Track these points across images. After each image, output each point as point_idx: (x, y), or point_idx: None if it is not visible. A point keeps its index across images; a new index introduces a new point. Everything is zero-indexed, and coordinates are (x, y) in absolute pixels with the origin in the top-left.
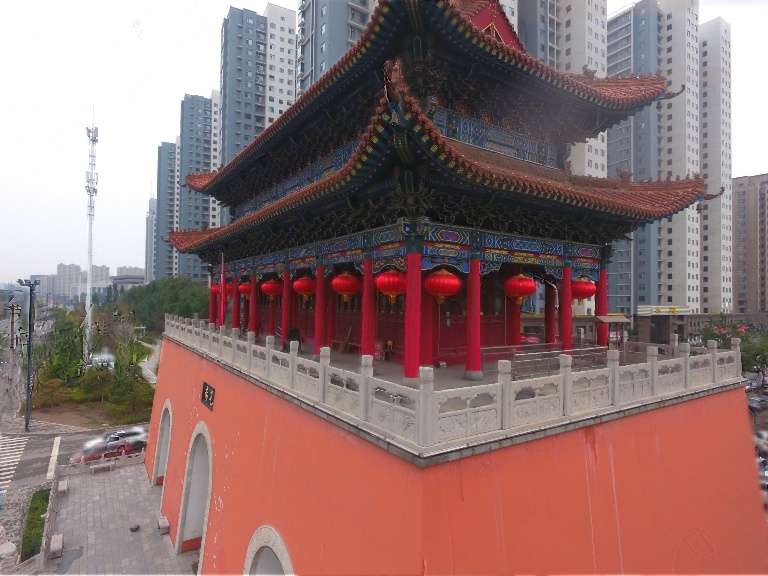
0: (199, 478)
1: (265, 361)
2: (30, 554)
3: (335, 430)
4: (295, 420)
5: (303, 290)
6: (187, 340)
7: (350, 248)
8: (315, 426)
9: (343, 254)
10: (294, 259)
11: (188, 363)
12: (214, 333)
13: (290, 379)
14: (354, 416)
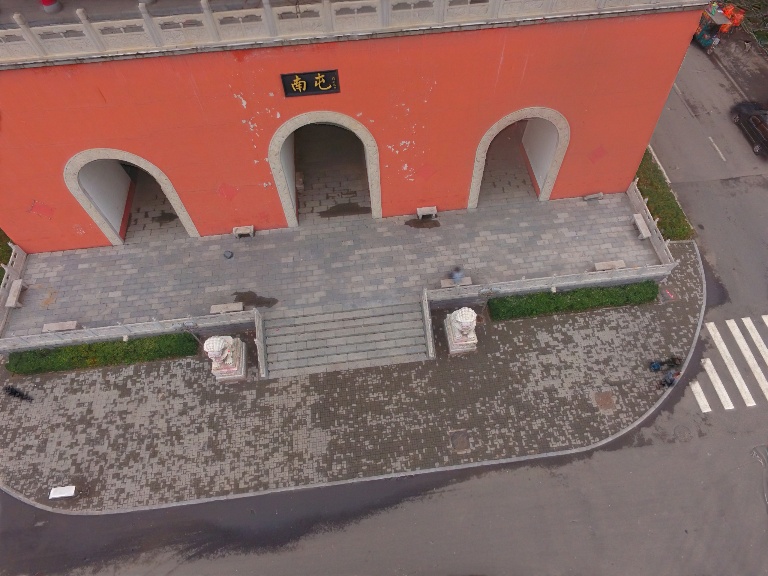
0: None
1: (488, 3)
2: (194, 343)
3: None
4: (561, 33)
5: None
6: (114, 47)
7: None
8: (596, 26)
9: None
10: None
11: (170, 75)
12: (284, 7)
13: None
14: (644, 4)
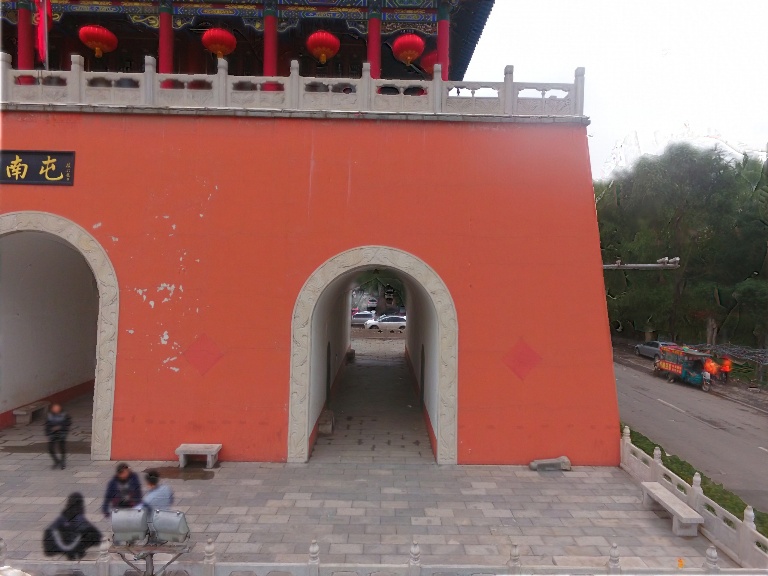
0: None
1: (283, 91)
2: None
3: (472, 128)
4: (391, 136)
5: (226, 43)
6: None
7: (343, 4)
8: (438, 131)
9: (325, 9)
10: (194, 1)
11: None
12: None
13: (367, 101)
14: (496, 113)
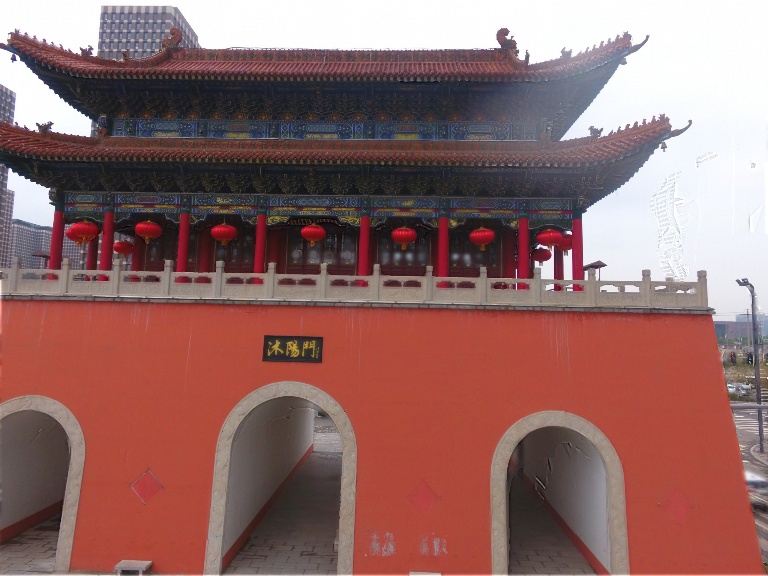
0: None
1: None
2: None
3: None
4: None
5: None
6: None
7: None
8: None
9: None
10: None
11: None
12: None
13: None
14: None
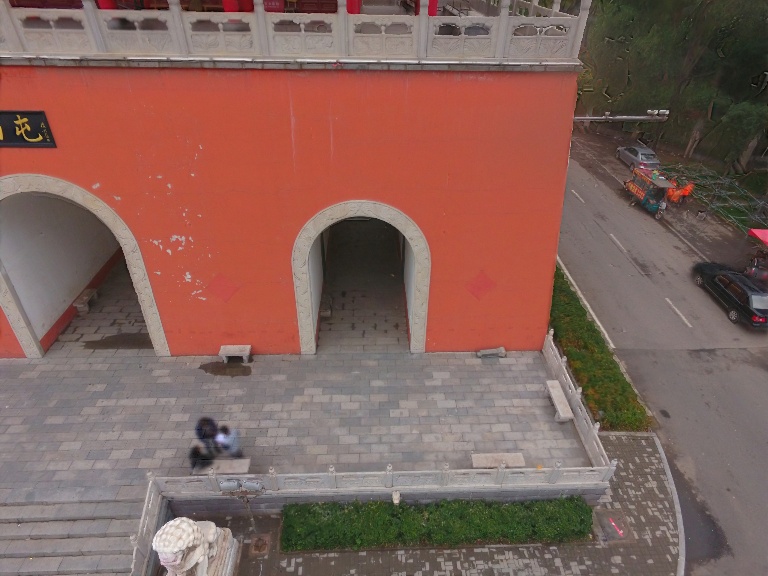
0: (12, 264)
1: (250, 32)
2: None
3: (458, 77)
4: (372, 88)
5: None
6: None
7: None
8: (422, 82)
9: None
10: None
11: None
12: None
13: (344, 45)
14: (485, 58)
